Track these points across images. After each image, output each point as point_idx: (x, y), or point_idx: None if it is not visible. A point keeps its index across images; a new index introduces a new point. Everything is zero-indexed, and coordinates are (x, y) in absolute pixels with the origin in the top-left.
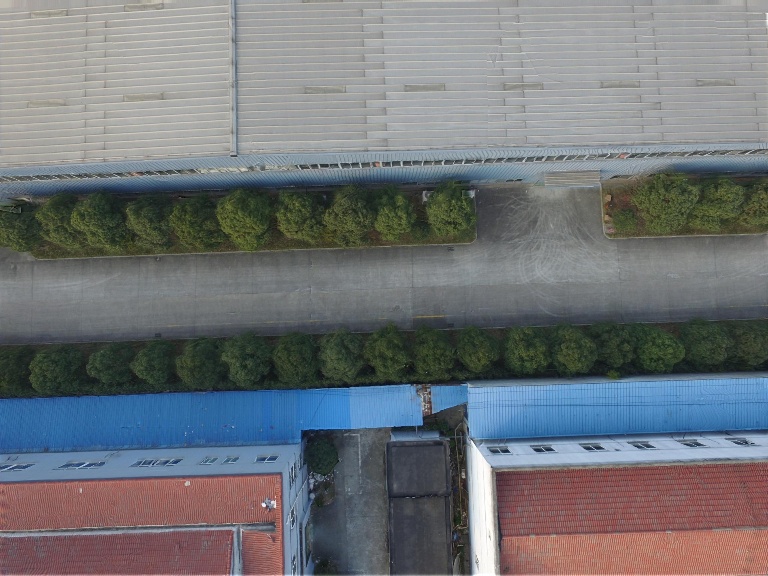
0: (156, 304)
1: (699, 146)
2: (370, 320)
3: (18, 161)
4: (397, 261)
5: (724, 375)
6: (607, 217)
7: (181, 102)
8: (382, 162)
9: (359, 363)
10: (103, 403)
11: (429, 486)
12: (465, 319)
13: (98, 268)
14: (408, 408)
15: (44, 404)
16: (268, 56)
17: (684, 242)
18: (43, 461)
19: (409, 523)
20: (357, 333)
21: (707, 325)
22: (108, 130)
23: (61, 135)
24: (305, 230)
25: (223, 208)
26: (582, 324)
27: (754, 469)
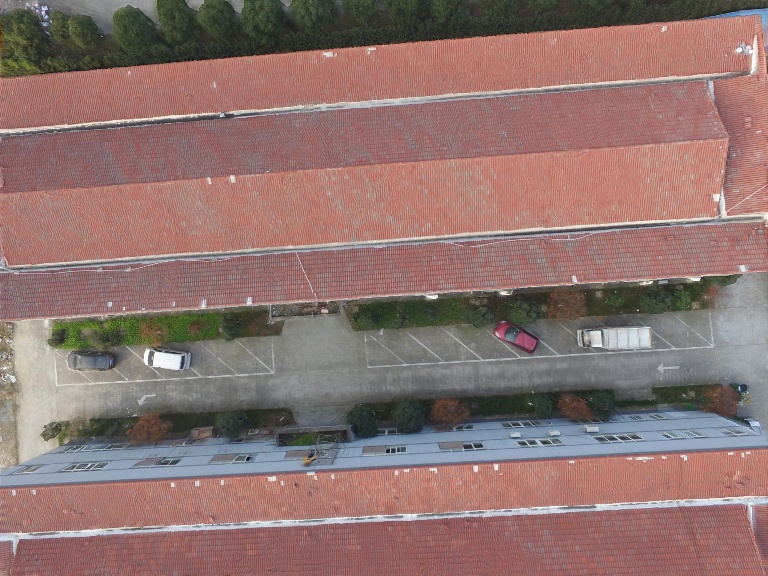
0: None
1: None
2: None
3: None
4: None
5: None
6: None
7: None
8: None
9: None
10: None
11: None
12: None
13: None
14: None
15: None
16: None
17: None
18: None
19: None
20: None
21: None
22: None
23: None
24: None
25: None
26: None
27: None
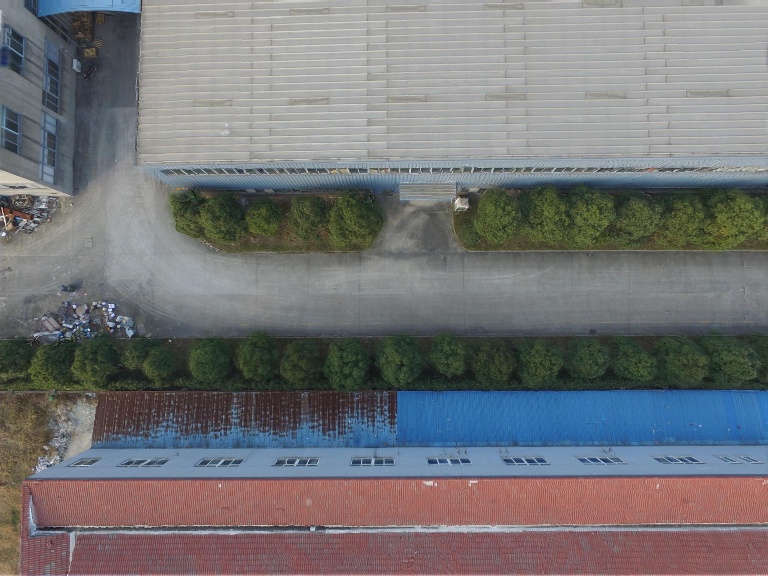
0: (590, 300)
1: None
2: None
3: (577, 153)
4: None
5: None
6: None
7: (741, 100)
8: None
9: None
10: (563, 398)
11: None
12: None
13: (530, 262)
14: None
15: (503, 397)
16: None
17: None
18: (545, 455)
19: None
20: None
21: None
22: (672, 125)
23: (616, 128)
24: None
25: (727, 207)
26: None
27: None
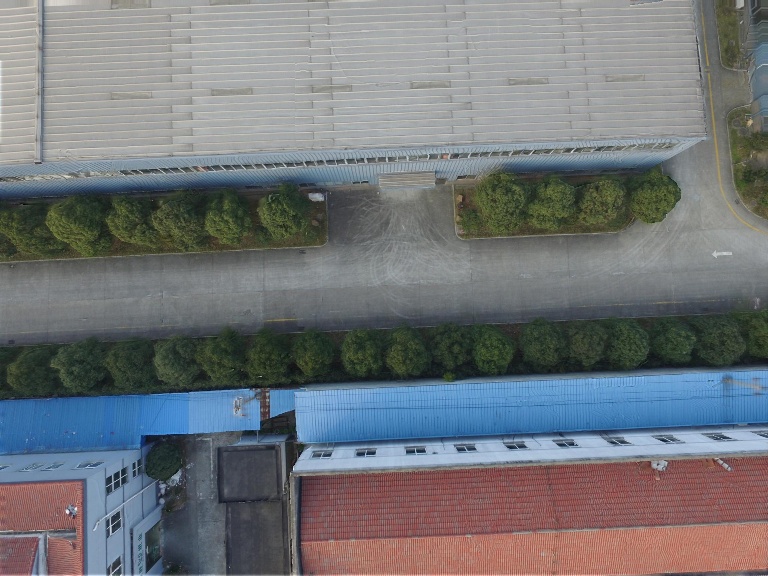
0: (10, 311)
1: (516, 145)
2: (221, 324)
3: None
4: (249, 265)
5: (556, 376)
6: (458, 218)
7: None
8: (201, 167)
9: (192, 368)
10: None
11: (260, 491)
12: (316, 322)
13: None
14: (246, 412)
15: None
16: (77, 63)
17: (537, 242)
18: None
19: (246, 528)
20: (200, 338)
21: (542, 326)
22: None
23: None
24: (137, 236)
25: None
26: (428, 326)
27: (568, 471)
